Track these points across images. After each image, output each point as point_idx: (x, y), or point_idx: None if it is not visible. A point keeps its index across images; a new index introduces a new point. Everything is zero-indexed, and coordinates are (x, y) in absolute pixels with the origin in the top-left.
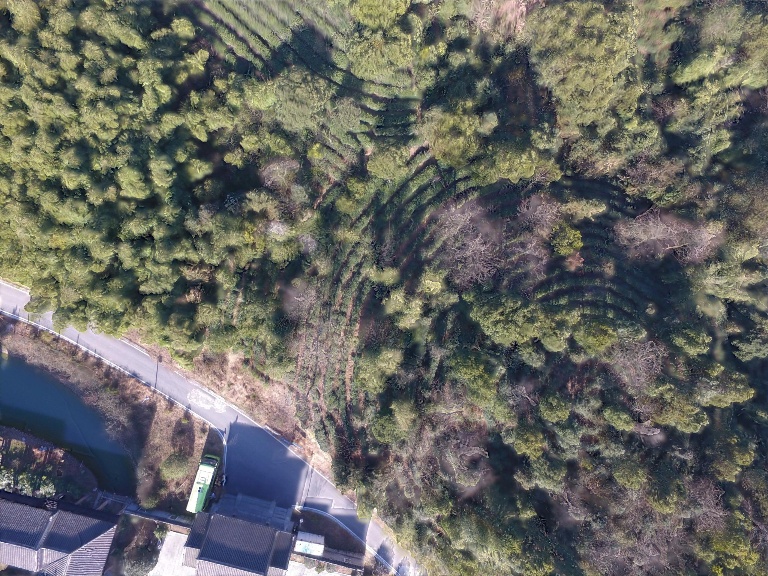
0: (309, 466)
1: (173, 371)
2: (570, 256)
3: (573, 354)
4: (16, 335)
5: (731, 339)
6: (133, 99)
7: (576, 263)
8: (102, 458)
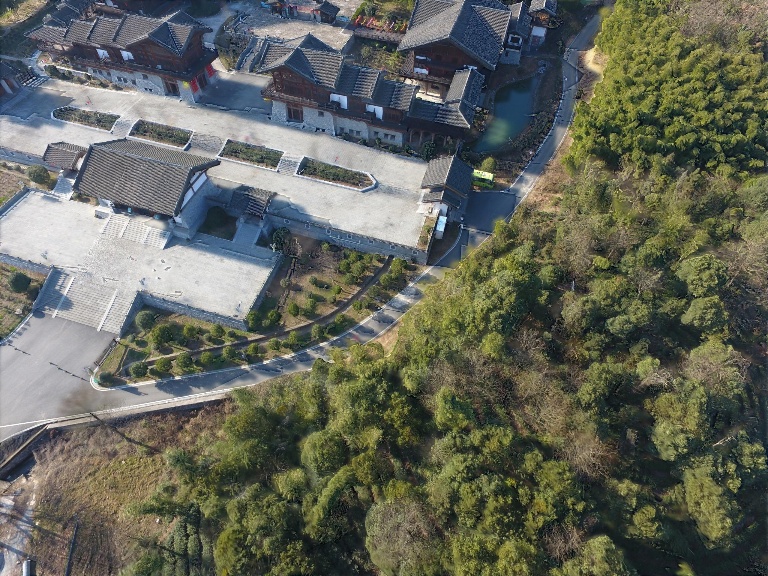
0: (491, 233)
1: (542, 170)
2: (767, 344)
3: (681, 347)
4: (547, 115)
5: (749, 575)
6: (719, 132)
7: (763, 350)
8: (481, 145)
